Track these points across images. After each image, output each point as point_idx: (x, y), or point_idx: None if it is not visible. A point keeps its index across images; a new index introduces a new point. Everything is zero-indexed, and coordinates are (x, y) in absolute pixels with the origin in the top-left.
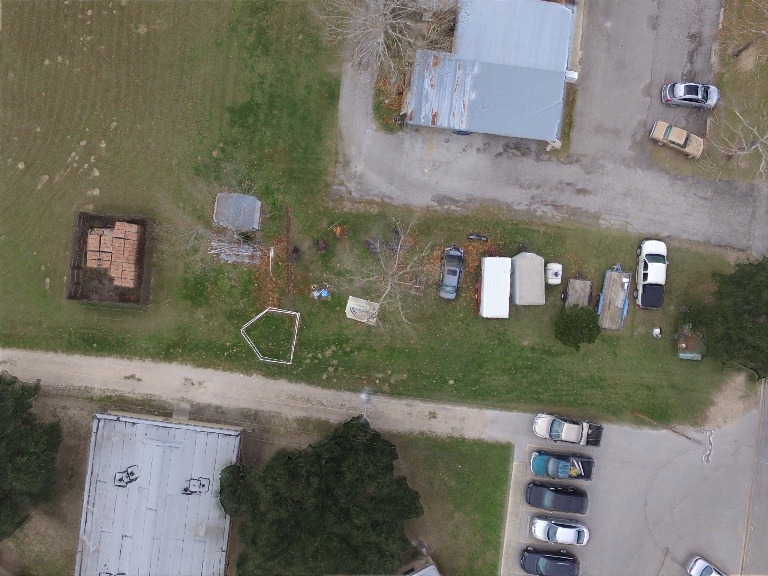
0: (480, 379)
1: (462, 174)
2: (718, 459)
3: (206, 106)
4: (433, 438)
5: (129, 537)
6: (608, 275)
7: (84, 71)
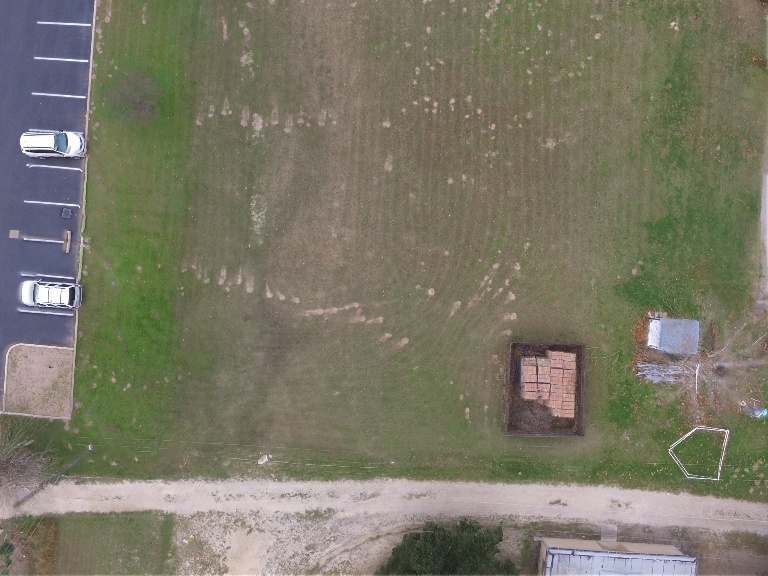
0: None
1: None
2: None
3: (623, 223)
4: None
5: None
6: None
7: (492, 190)
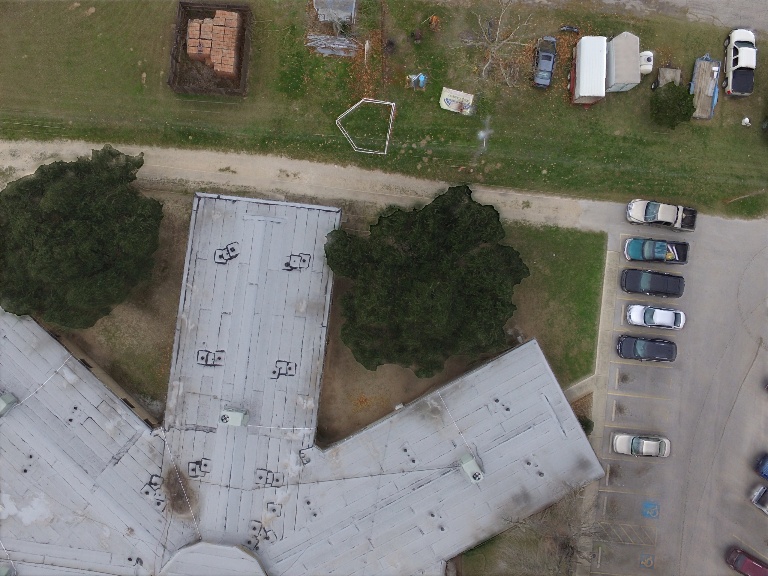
0: (573, 169)
1: None
2: None
3: None
4: (527, 227)
5: (228, 314)
6: (698, 64)
7: None
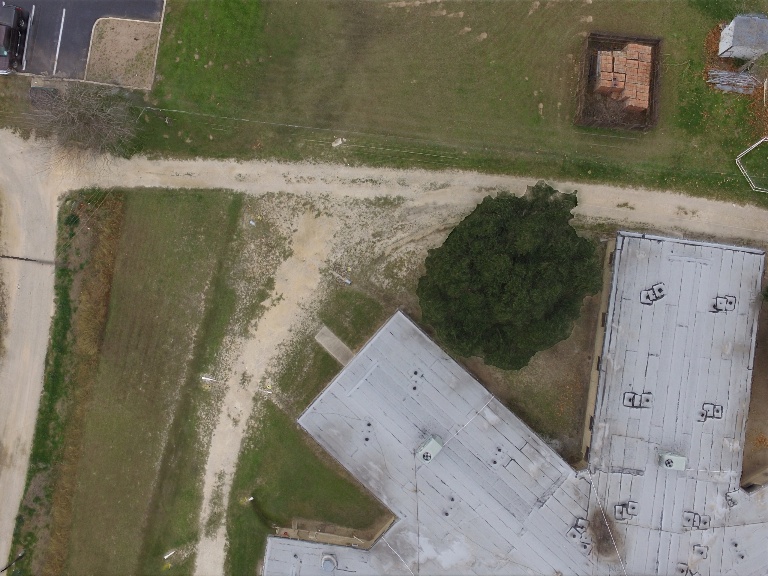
0: None
1: None
2: None
3: None
4: None
5: (656, 355)
6: None
7: None
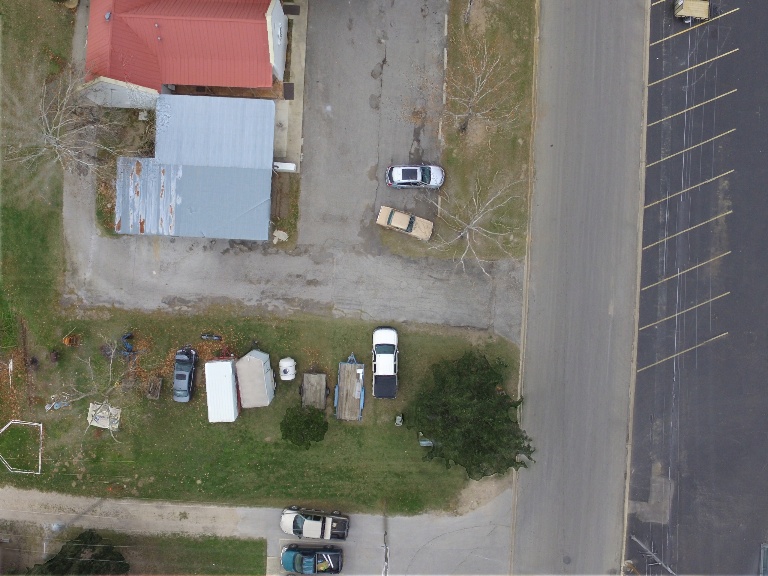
0: (227, 477)
1: (191, 274)
2: (473, 541)
3: None
4: (185, 538)
5: None
6: (342, 367)
7: None
